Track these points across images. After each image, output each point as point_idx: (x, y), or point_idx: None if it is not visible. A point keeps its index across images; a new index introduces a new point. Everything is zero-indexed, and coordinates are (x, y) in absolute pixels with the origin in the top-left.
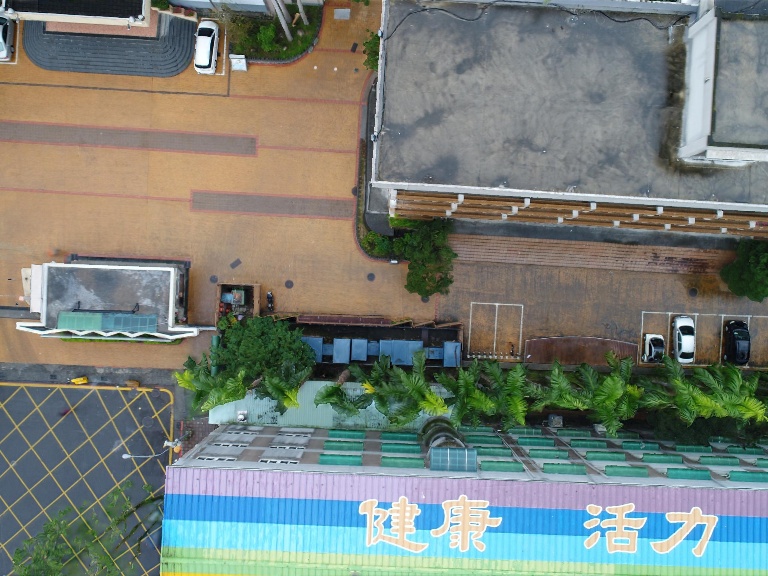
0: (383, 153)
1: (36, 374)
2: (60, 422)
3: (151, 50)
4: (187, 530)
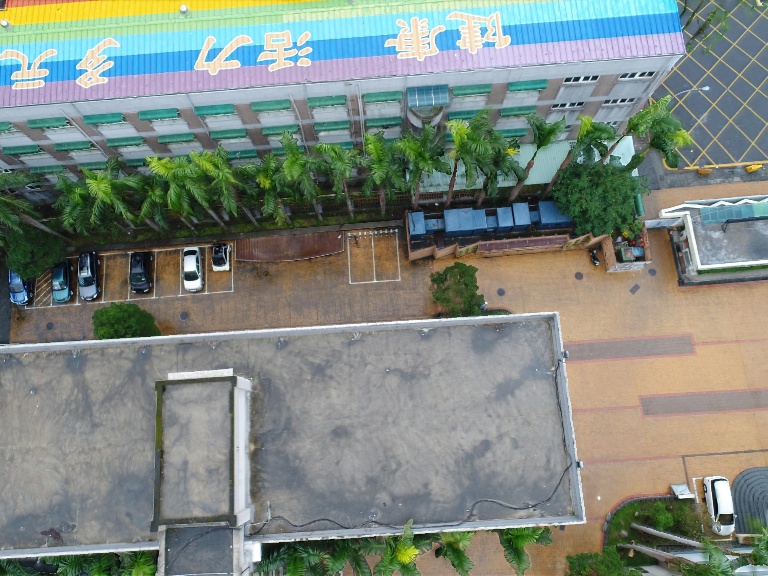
0: (549, 349)
1: None
2: (761, 131)
3: None
4: (656, 6)
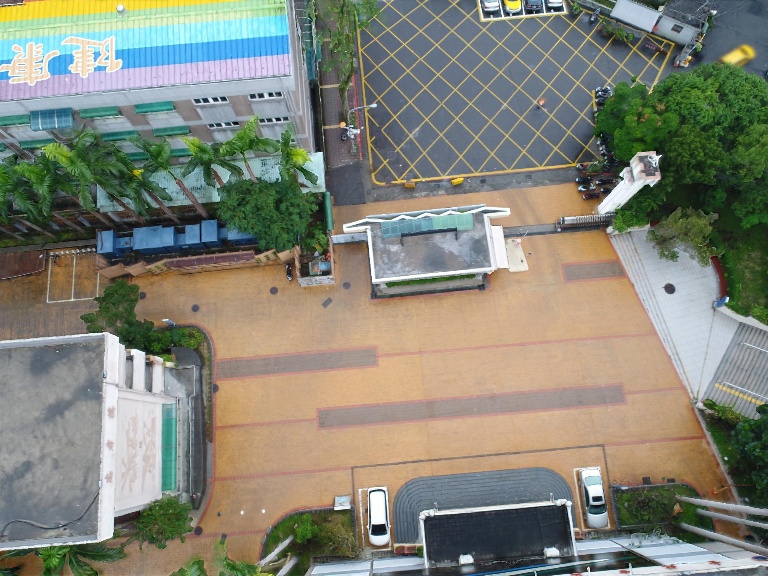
0: None
1: (499, 182)
2: (470, 145)
3: (433, 502)
4: (267, 29)
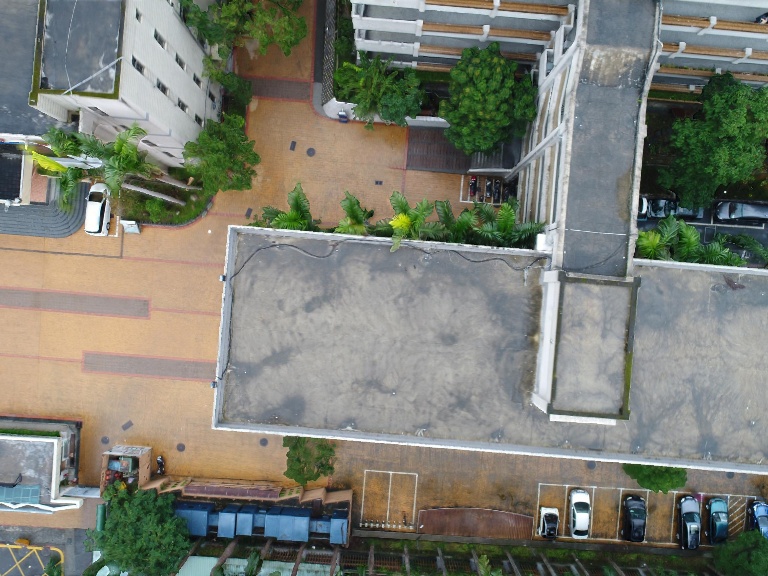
0: (228, 392)
1: None
2: None
3: (41, 214)
4: None
